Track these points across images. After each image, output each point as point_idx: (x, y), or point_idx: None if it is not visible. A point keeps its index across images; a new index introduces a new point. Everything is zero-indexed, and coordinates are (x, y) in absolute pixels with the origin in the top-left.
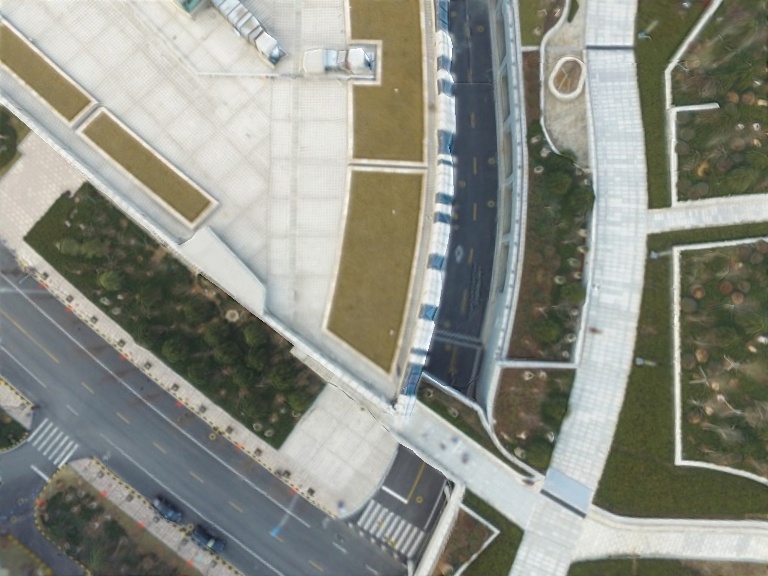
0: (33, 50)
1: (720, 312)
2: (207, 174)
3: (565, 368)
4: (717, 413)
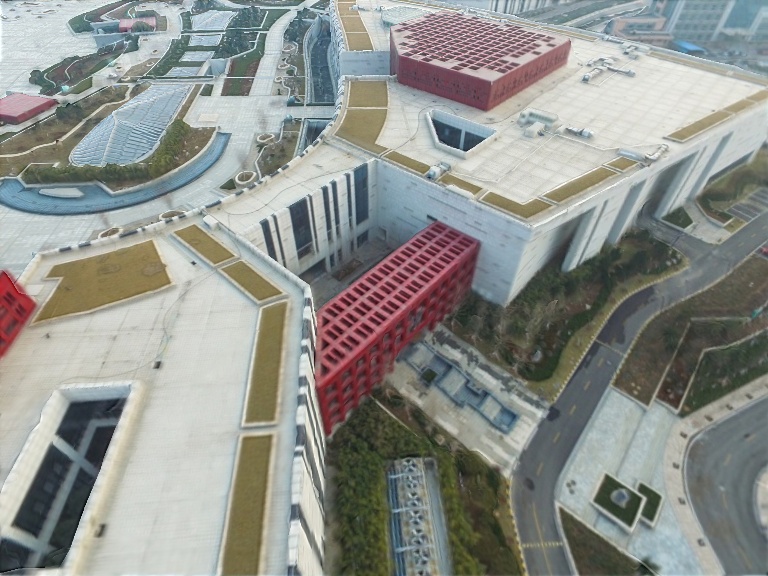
0: (442, 8)
1: (254, 15)
2: (393, 2)
3: (296, 19)
4: (257, 13)
